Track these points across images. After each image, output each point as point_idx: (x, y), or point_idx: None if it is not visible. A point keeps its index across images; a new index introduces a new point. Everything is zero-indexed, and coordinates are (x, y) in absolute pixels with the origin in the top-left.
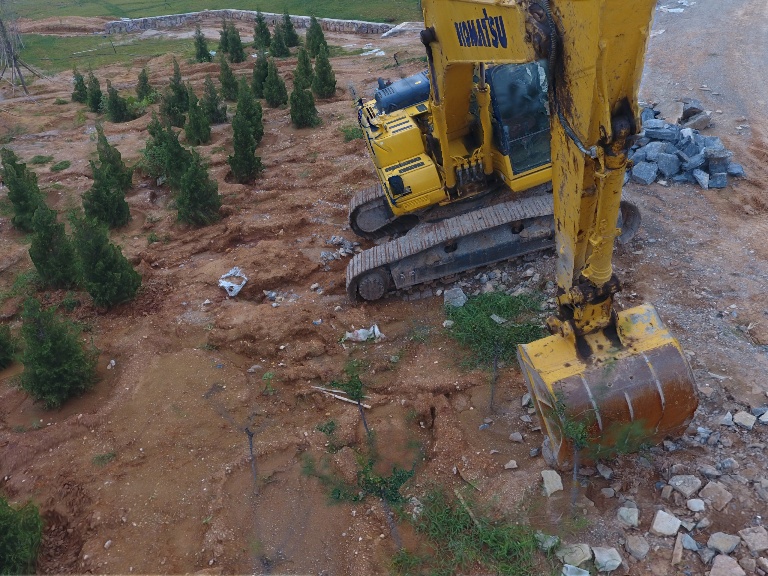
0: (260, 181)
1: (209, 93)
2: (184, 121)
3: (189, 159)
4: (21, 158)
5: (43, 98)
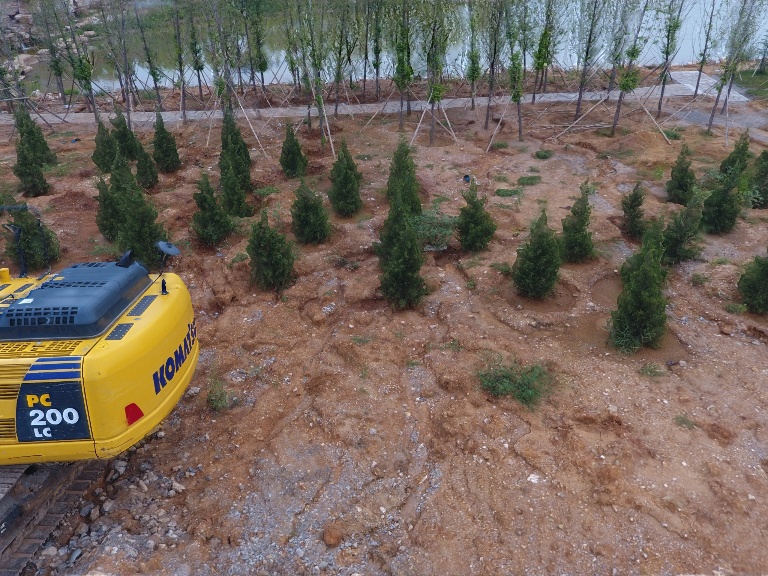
0: (378, 309)
1: (684, 220)
2: (641, 232)
3: (394, 239)
4: (537, 171)
5: (761, 142)
